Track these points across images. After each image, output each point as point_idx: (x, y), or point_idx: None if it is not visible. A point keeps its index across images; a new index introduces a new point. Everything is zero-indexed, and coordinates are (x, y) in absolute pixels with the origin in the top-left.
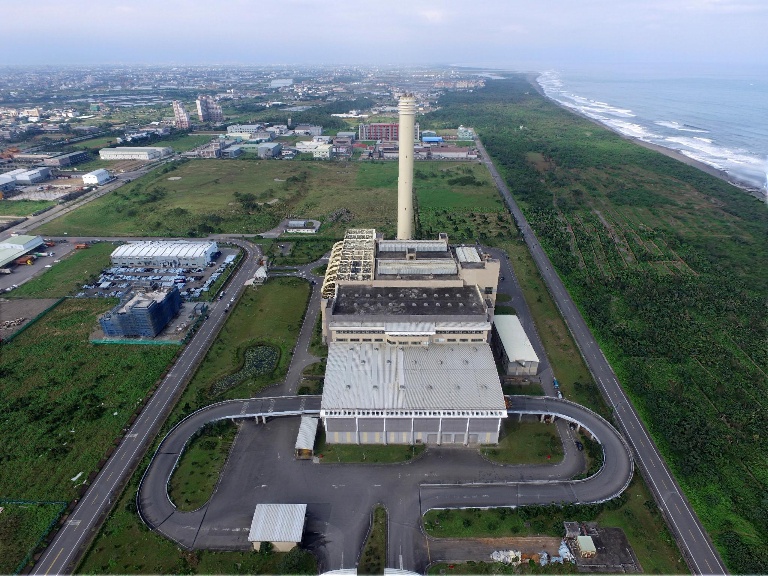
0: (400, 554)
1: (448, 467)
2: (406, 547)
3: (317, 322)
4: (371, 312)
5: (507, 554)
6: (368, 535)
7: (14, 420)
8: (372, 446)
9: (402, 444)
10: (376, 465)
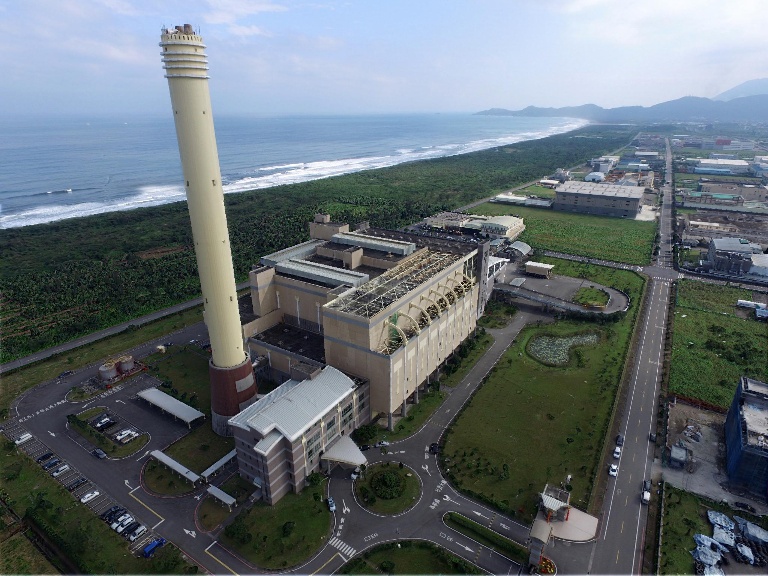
0: None
1: None
2: None
3: (469, 367)
4: (450, 242)
5: None
6: None
7: None
8: None
9: None
10: None
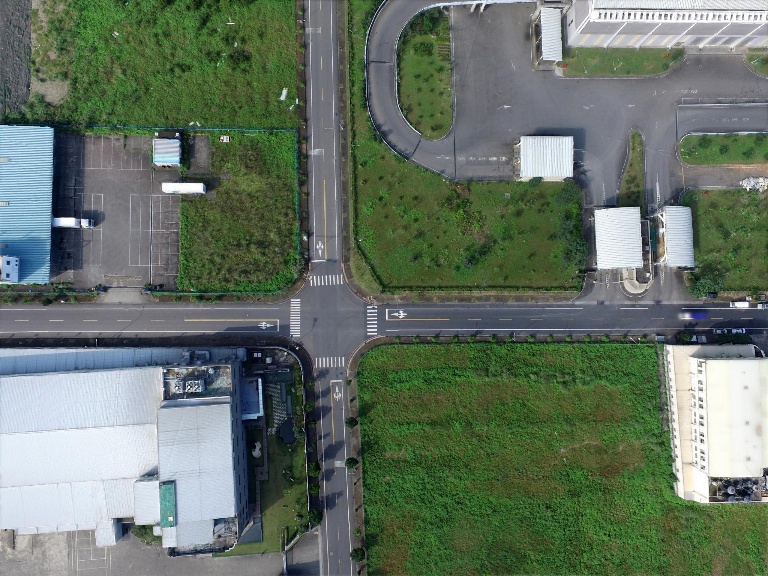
0: (657, 182)
1: (709, 81)
2: (663, 175)
3: None
4: None
5: (757, 181)
6: (626, 163)
7: (137, 3)
8: (622, 50)
9: (658, 47)
10: (628, 78)
